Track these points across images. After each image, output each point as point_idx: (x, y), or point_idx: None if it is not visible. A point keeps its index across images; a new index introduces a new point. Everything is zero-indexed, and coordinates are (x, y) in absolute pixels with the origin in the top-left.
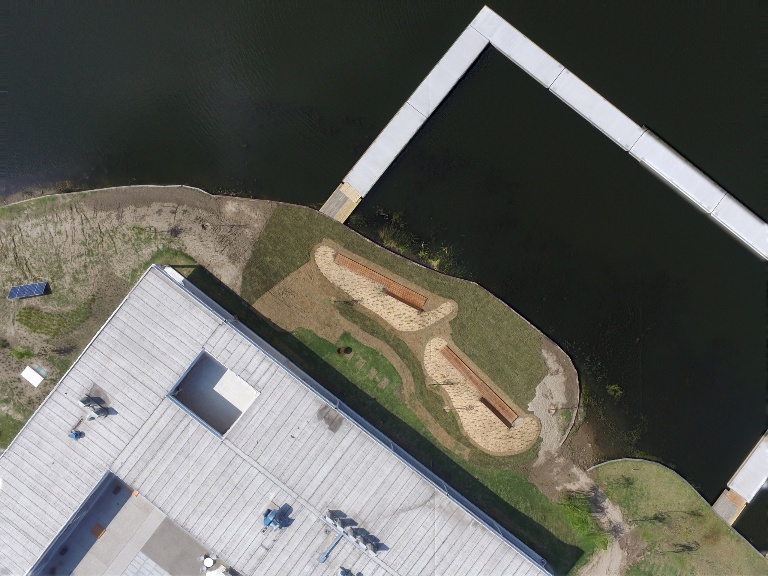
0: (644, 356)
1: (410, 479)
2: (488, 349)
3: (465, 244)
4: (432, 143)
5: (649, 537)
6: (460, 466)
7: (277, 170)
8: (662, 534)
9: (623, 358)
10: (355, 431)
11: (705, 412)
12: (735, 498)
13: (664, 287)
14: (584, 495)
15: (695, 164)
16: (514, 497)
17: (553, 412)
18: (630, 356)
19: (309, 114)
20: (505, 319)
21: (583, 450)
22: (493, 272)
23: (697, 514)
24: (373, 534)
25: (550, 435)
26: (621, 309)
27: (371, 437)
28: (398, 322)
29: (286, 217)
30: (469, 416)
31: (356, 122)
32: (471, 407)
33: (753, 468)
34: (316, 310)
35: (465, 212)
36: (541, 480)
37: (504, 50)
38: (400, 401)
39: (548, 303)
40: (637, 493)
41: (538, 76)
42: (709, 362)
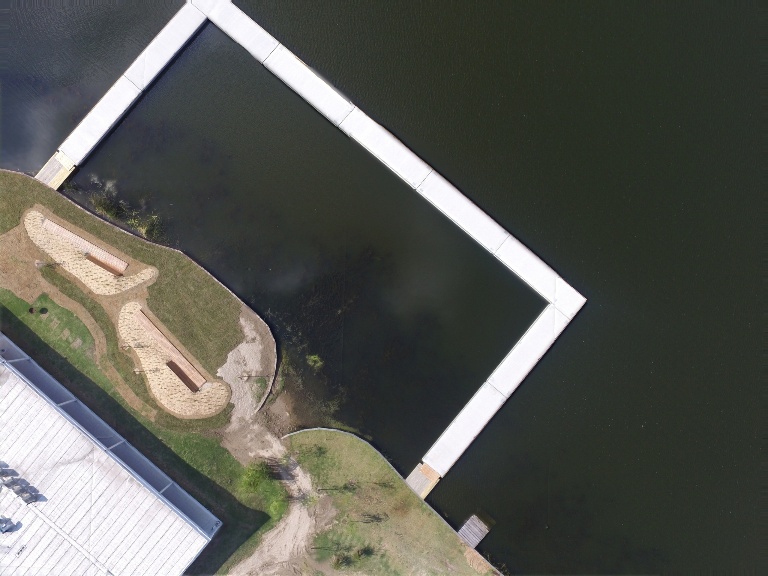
0: (346, 328)
1: (70, 433)
2: (183, 315)
3: (172, 213)
4: (148, 115)
5: (338, 506)
6: (145, 427)
7: (1, 138)
8: (351, 504)
9: (324, 329)
10: (21, 385)
11: (405, 386)
12: (428, 472)
13: (368, 261)
14: (276, 462)
15: (402, 141)
16: (199, 460)
17: (245, 379)
18: (332, 328)
19: (33, 85)
20: (205, 287)
21: (281, 418)
22: (199, 241)
23: (389, 486)
24: (33, 485)
25: (243, 401)
26: (324, 281)
27: (35, 391)
28: (96, 285)
29: (2, 183)
30: (156, 378)
31: (77, 94)
32: (157, 370)
33: (448, 443)
34: (19, 272)
35: (177, 183)
36: (234, 445)
37: (221, 26)
38: (92, 362)
39: (253, 273)
40: (328, 462)
41: (252, 52)
42: (411, 337)
